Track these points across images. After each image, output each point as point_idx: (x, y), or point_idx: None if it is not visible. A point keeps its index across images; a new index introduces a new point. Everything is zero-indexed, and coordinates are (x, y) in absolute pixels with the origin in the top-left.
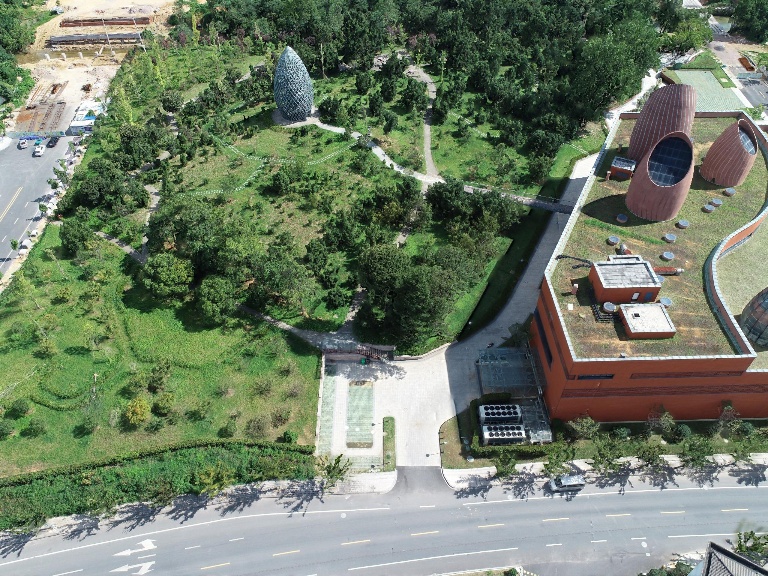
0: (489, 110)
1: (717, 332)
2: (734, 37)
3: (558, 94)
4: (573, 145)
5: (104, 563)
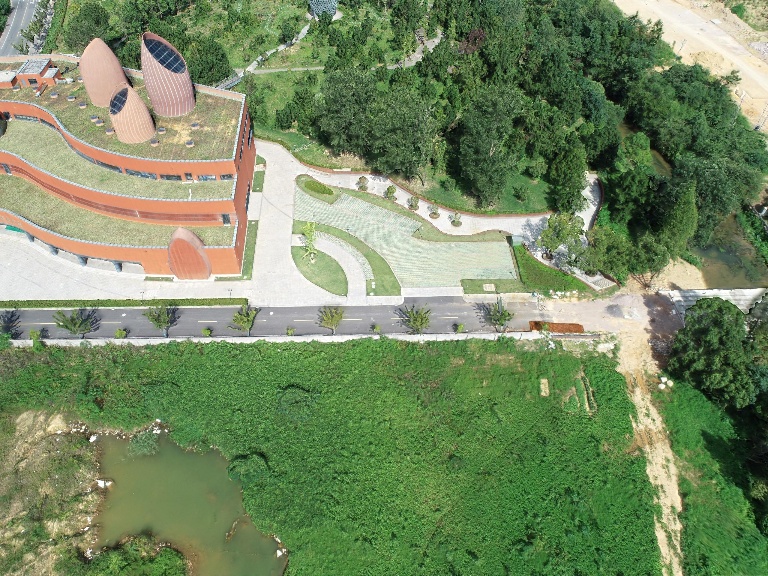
0: None
1: None
2: None
3: None
4: (308, 145)
5: None
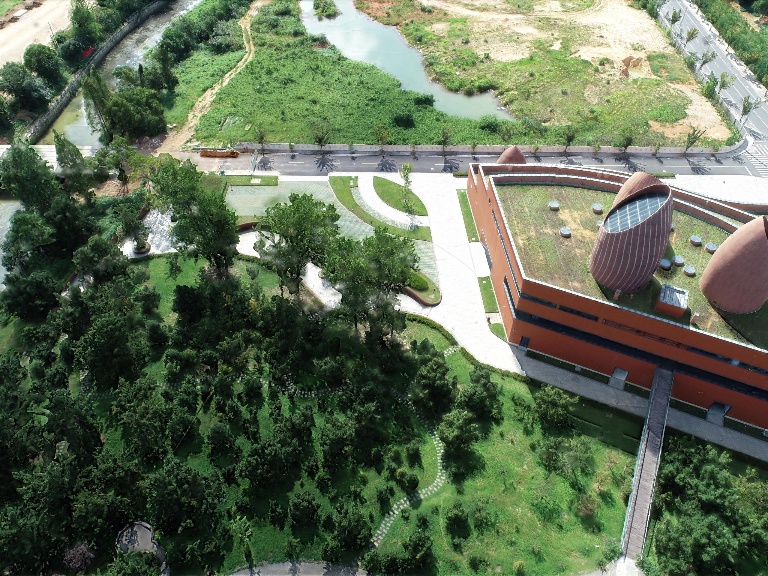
0: (350, 464)
1: None
2: (135, 145)
3: (302, 353)
4: None
5: None
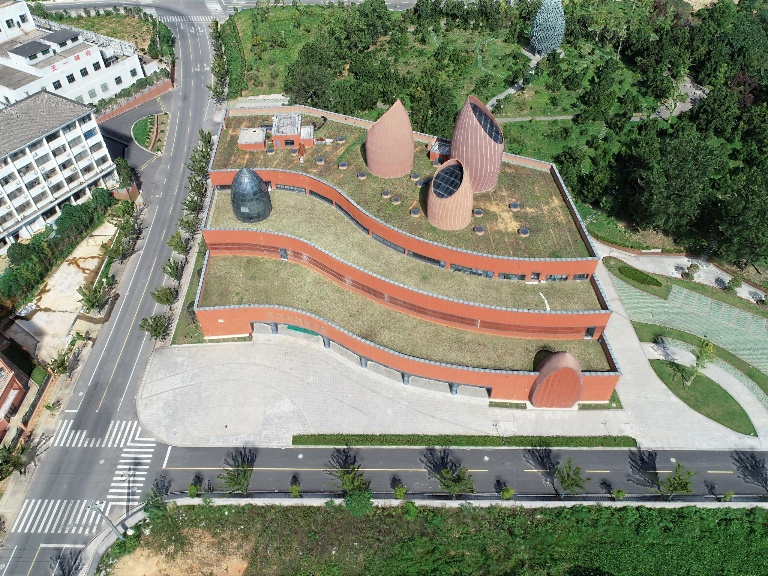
0: None
1: None
2: None
3: (702, 206)
4: (594, 216)
5: None
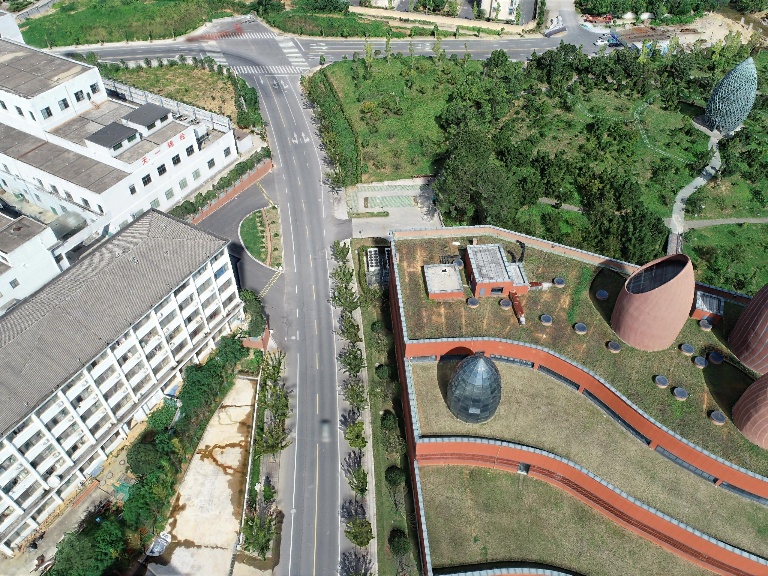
0: None
1: (441, 334)
2: None
3: None
4: None
5: (298, 130)
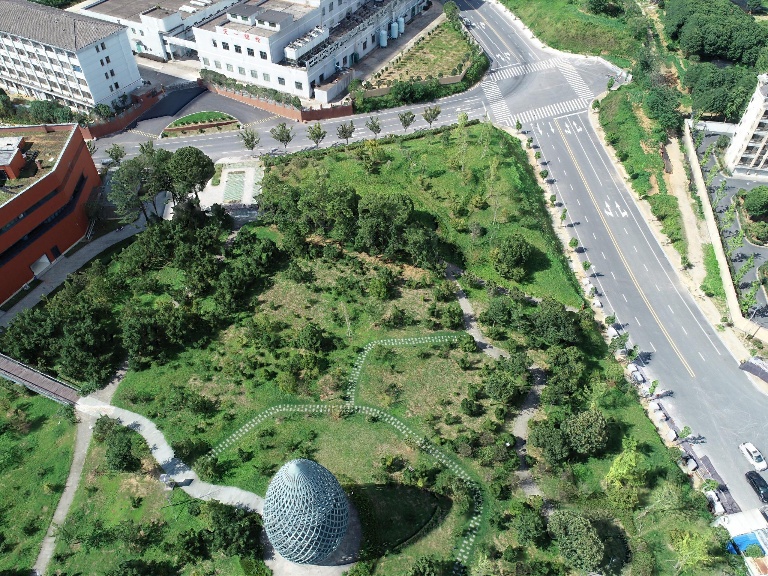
0: None
1: None
2: None
3: None
4: None
5: None
